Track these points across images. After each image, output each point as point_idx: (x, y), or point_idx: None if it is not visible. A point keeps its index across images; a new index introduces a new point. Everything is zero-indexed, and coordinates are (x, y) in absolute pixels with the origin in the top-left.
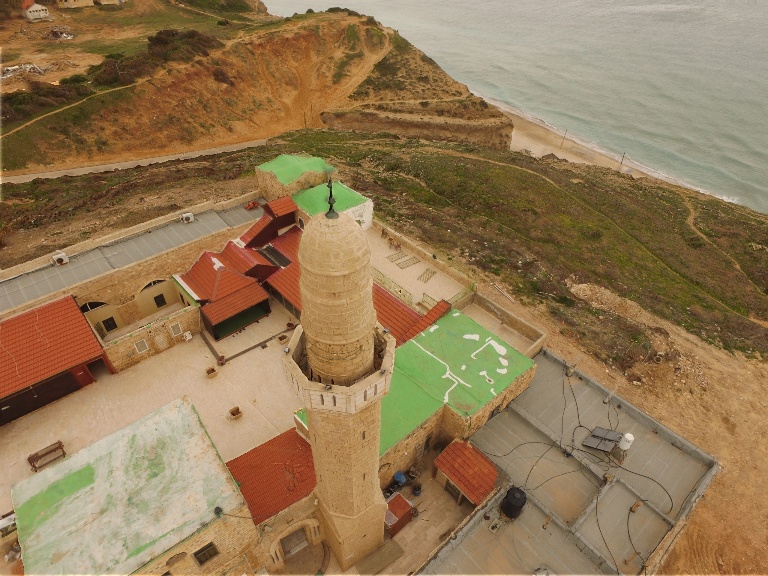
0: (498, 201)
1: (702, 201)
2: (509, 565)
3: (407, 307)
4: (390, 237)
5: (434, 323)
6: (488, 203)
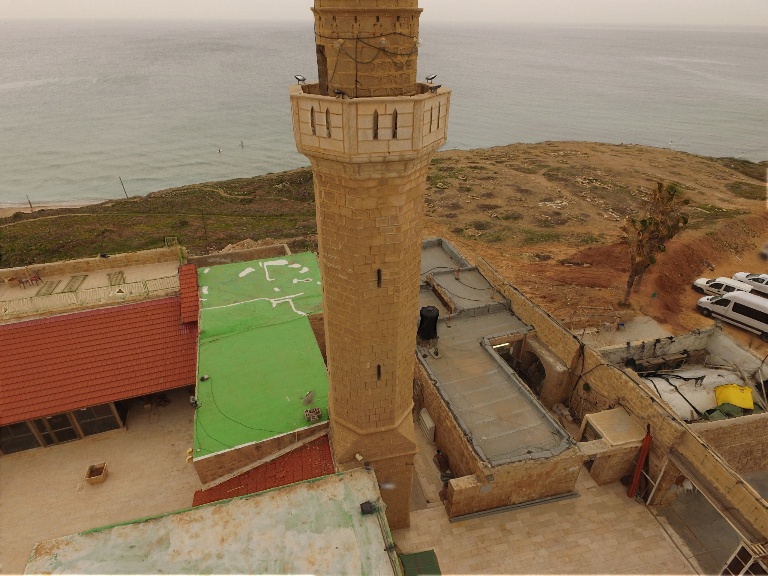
0: (57, 243)
1: (213, 185)
2: (471, 359)
3: (145, 302)
4: (6, 280)
5: (199, 287)
6: (47, 249)
